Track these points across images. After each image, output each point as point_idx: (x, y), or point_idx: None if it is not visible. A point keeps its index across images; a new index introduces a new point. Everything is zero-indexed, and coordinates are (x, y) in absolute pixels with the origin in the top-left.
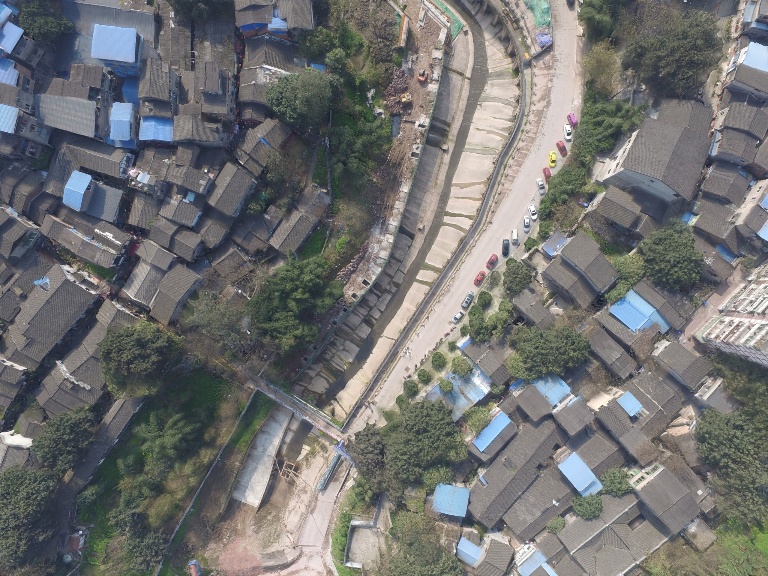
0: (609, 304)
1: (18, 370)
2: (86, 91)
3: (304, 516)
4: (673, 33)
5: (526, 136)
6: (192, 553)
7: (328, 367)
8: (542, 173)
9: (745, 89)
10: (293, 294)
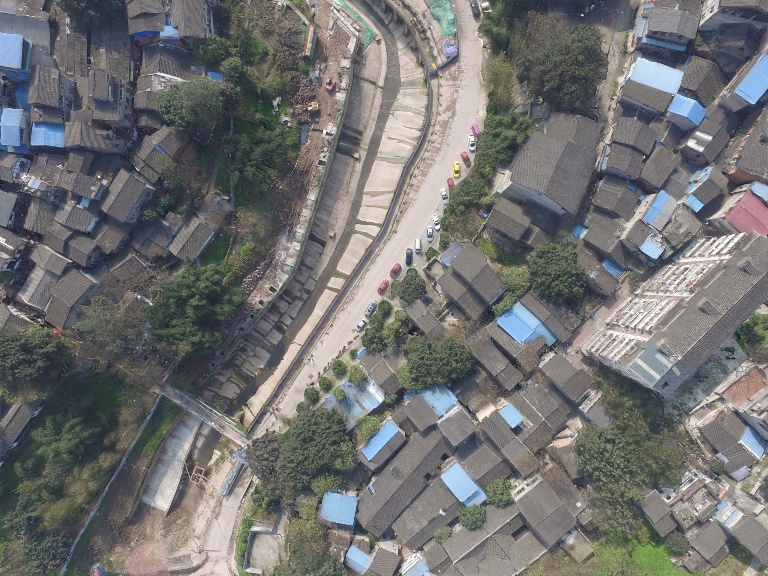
0: None
1: None
2: None
3: (210, 521)
4: (557, 48)
5: (431, 146)
6: (98, 556)
7: (239, 373)
8: (446, 183)
9: (635, 104)
10: (190, 301)
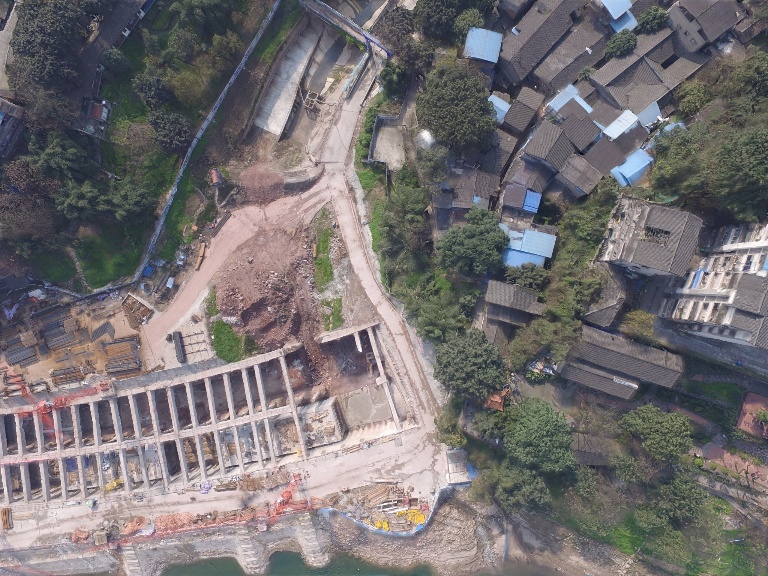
0: None
1: None
2: None
3: (328, 131)
4: None
5: None
6: (213, 166)
7: None
8: None
9: None
10: None
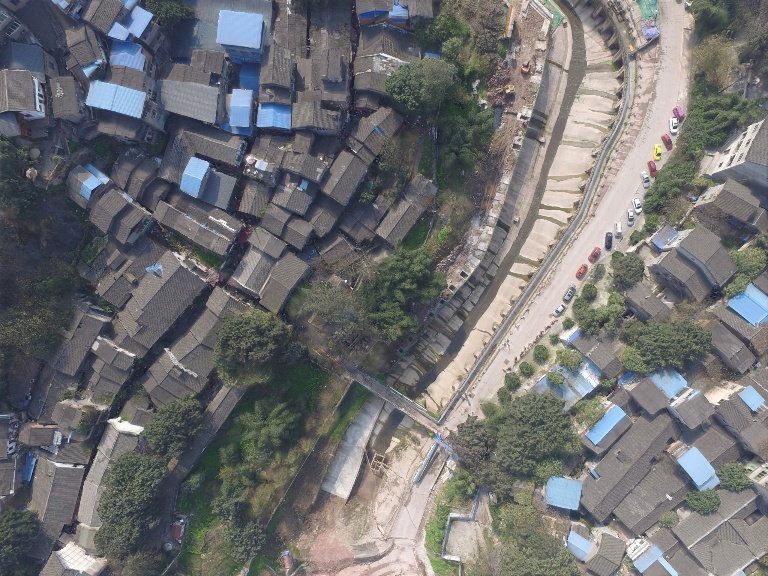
0: (725, 298)
1: (130, 356)
2: (207, 77)
3: (397, 508)
4: None
5: (630, 129)
6: (284, 544)
7: (420, 359)
8: (646, 166)
9: None
10: (401, 284)
